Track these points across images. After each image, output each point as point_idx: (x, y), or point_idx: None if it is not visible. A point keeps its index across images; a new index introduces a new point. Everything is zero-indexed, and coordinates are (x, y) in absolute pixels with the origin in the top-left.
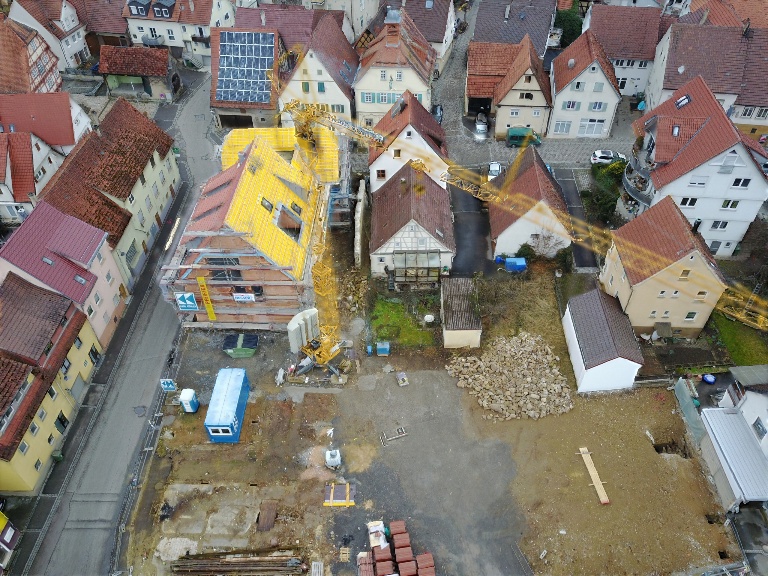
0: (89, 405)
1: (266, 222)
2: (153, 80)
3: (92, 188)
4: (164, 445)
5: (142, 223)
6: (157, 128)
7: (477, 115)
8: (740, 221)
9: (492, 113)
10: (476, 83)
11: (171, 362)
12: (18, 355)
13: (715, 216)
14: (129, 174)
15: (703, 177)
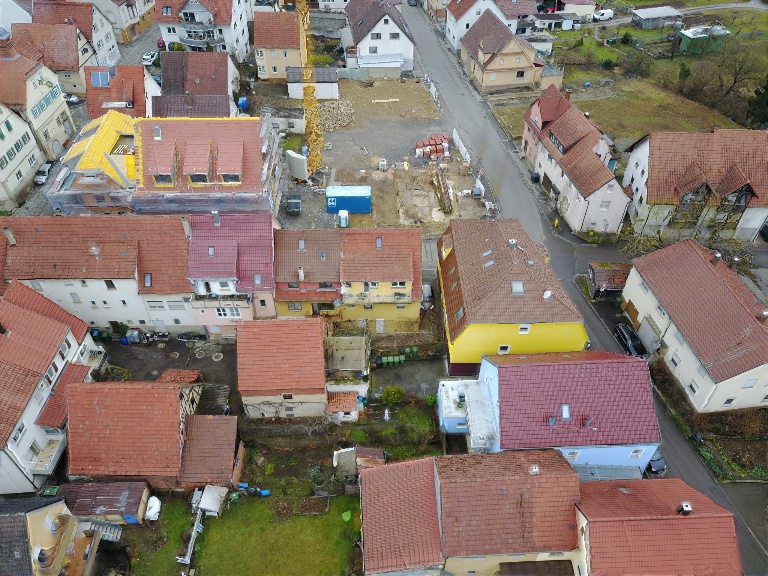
0: None
1: None
2: None
3: None
4: None
5: None
6: None
7: None
8: (245, 25)
9: None
10: None
11: None
12: None
13: (241, 28)
14: None
15: (233, 7)
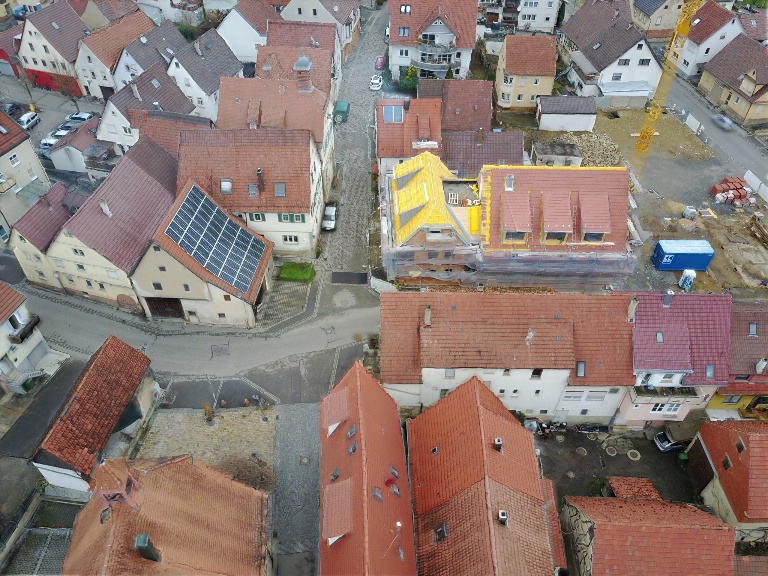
0: None
1: None
2: (138, 389)
3: None
4: None
5: None
6: None
7: None
8: None
9: None
10: None
11: None
12: None
13: None
14: None
15: None
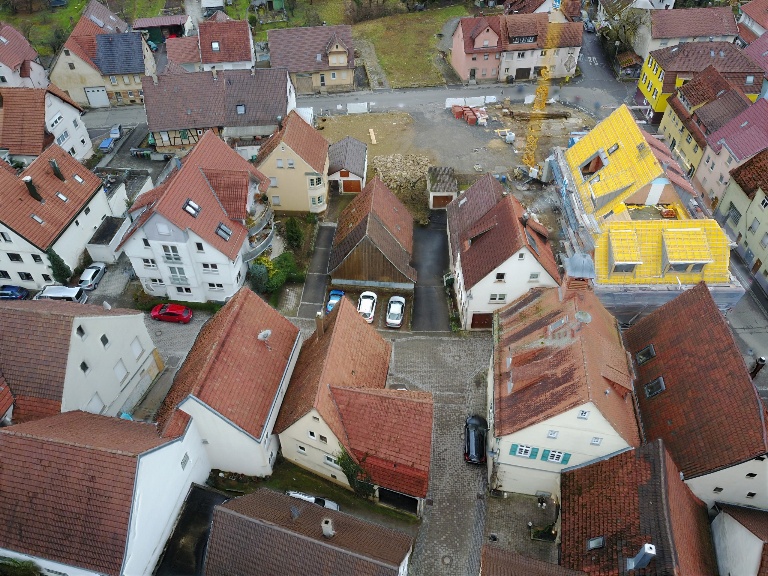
0: None
1: None
2: None
3: None
4: None
5: (752, 230)
6: None
7: None
8: None
9: None
10: None
11: None
12: None
13: None
14: None
15: None
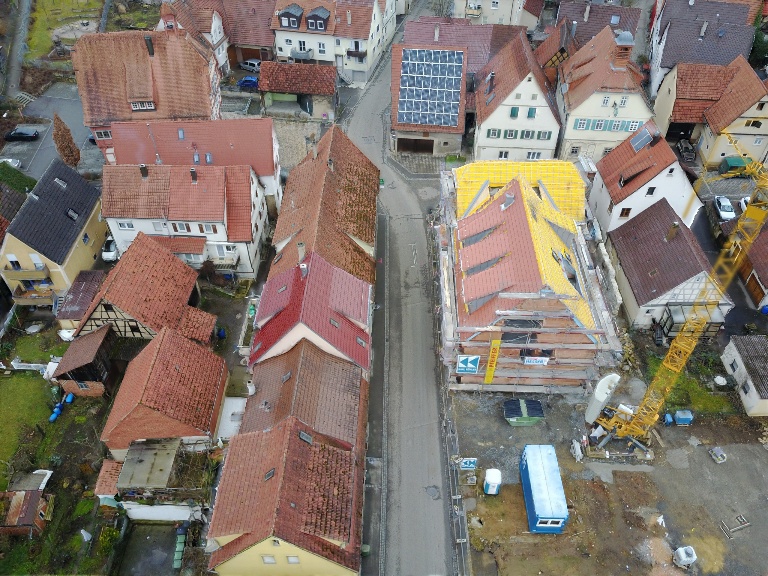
0: (373, 484)
1: (561, 277)
2: (317, 99)
3: (343, 233)
4: (476, 535)
5: None
6: (366, 158)
7: (680, 141)
8: None
9: (692, 139)
10: (684, 107)
11: (445, 431)
12: (337, 440)
13: None
14: (367, 214)
15: None
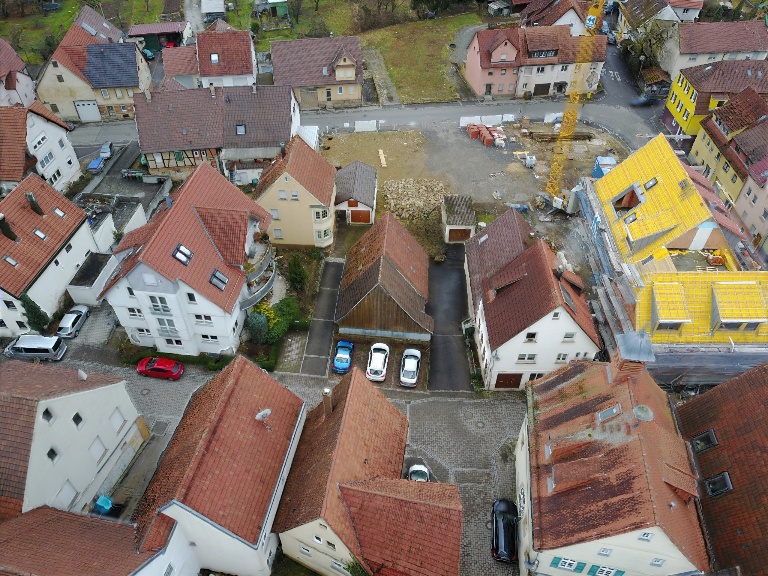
0: None
1: None
2: None
3: None
4: None
5: None
6: None
7: None
8: None
9: None
10: None
11: None
12: None
13: None
14: None
15: None
